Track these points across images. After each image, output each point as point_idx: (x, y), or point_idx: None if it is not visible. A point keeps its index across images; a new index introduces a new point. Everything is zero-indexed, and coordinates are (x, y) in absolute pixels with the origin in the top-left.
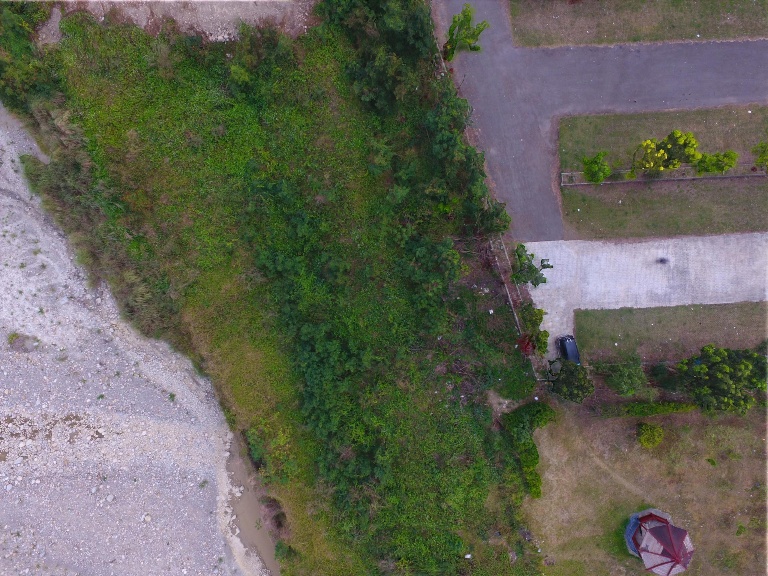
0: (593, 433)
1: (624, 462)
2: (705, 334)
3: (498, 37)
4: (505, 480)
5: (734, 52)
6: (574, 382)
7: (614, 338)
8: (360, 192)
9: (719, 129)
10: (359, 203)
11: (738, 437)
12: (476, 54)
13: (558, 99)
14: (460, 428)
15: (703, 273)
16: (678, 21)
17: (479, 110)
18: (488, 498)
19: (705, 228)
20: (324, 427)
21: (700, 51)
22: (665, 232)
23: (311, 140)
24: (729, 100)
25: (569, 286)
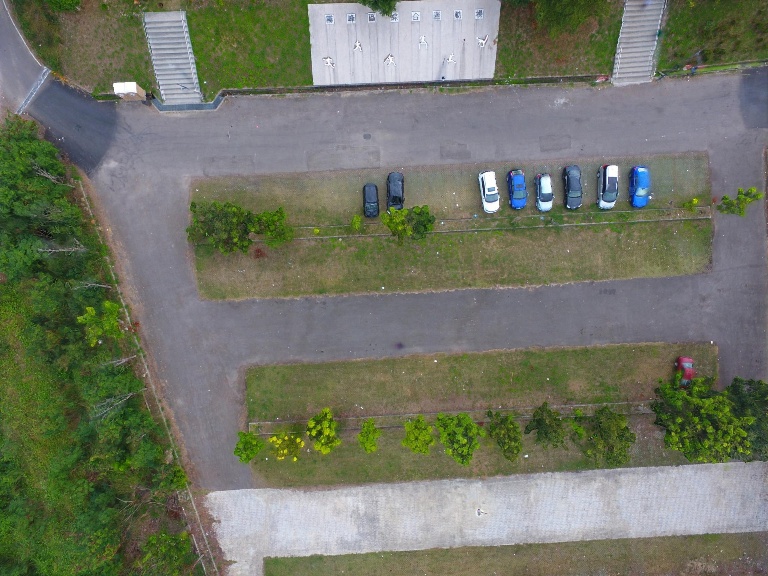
0: None
1: None
2: None
3: (184, 291)
4: None
5: (419, 303)
6: None
7: None
8: (46, 444)
9: (406, 378)
10: (44, 455)
11: None
12: (162, 307)
13: (245, 350)
14: None
15: (393, 520)
16: (363, 274)
17: (166, 362)
18: None
19: (394, 475)
20: None
21: (385, 303)
22: (354, 480)
23: (3, 388)
24: (415, 350)
25: (258, 534)
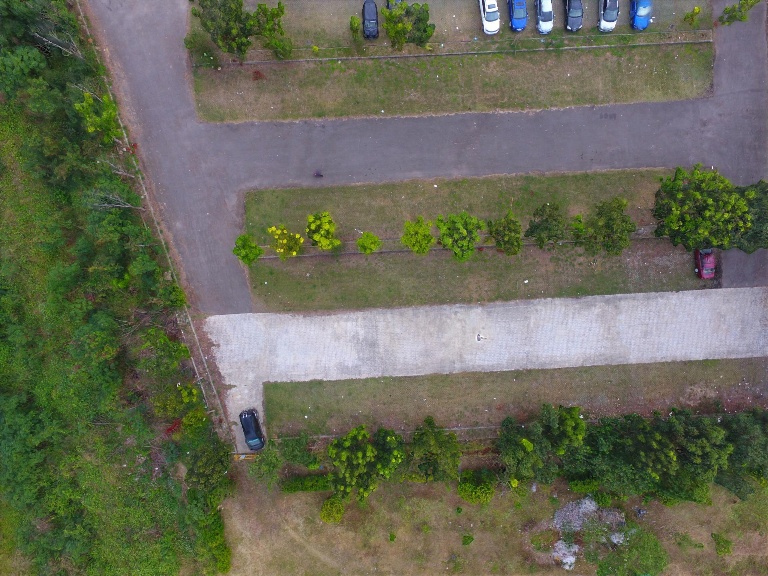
0: (286, 506)
1: (319, 535)
2: (395, 406)
3: (182, 113)
4: (197, 554)
5: (419, 127)
6: (194, 470)
7: (304, 411)
8: (44, 266)
9: (406, 203)
10: (42, 277)
11: (433, 509)
12: (160, 129)
13: (244, 173)
14: (149, 502)
15: (392, 345)
16: (362, 97)
17: (164, 184)
18: (182, 572)
19: (394, 301)
20: (20, 499)
21: (385, 126)
22: (354, 305)
23: (0, 213)
24: (415, 174)
25: (258, 359)
